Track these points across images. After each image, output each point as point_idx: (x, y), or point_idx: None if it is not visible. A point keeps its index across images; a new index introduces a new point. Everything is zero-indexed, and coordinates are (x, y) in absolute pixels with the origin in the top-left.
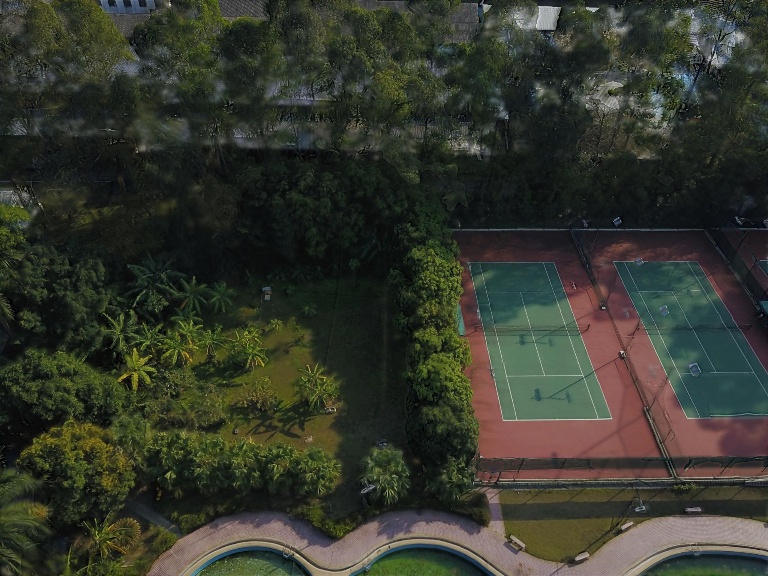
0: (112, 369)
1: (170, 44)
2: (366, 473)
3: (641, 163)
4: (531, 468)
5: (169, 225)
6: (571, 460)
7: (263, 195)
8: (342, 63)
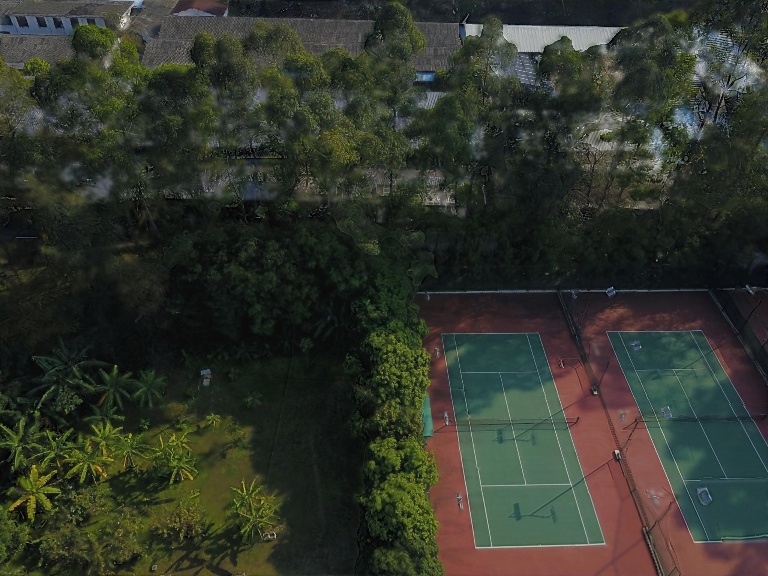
0: (9, 487)
1: (76, 98)
2: None
3: (637, 217)
4: None
5: (84, 307)
6: None
7: (197, 268)
8: (281, 121)
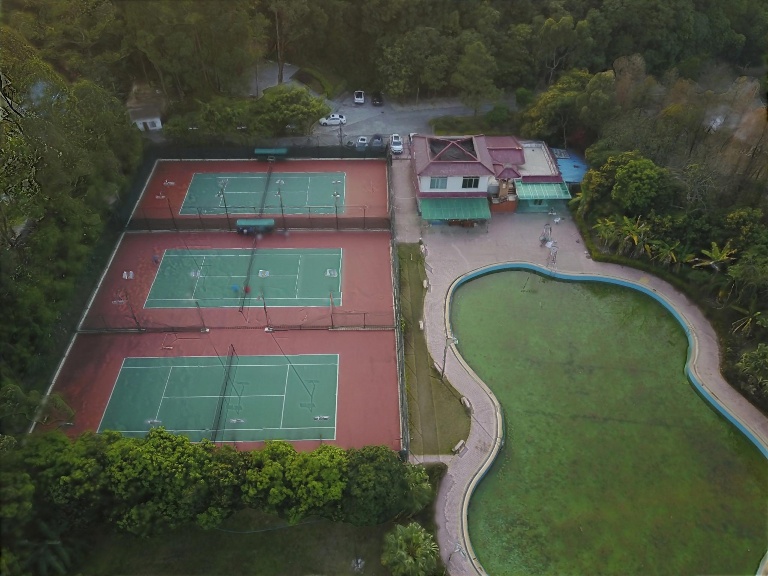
0: None
1: None
2: (415, 570)
3: None
4: None
5: None
6: None
7: None
8: None
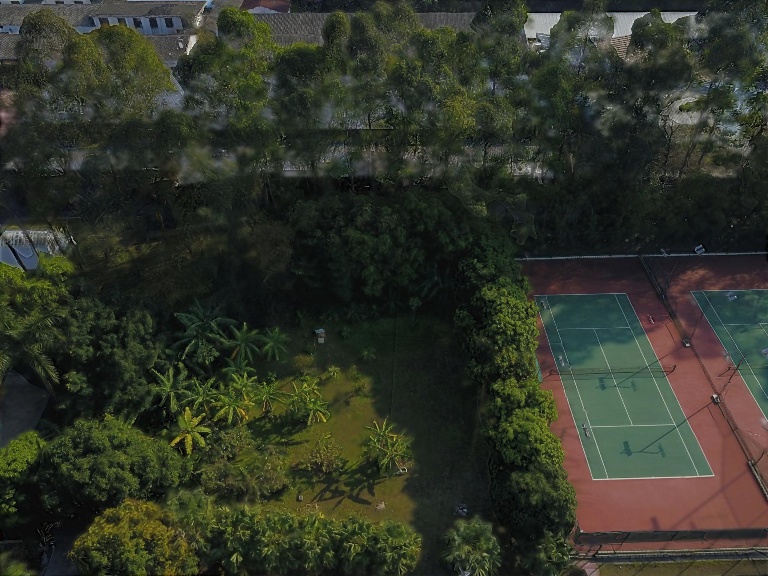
0: (162, 429)
1: (218, 75)
2: (452, 550)
3: (716, 183)
4: (636, 541)
5: (218, 268)
6: (684, 533)
7: (316, 232)
8: (406, 91)
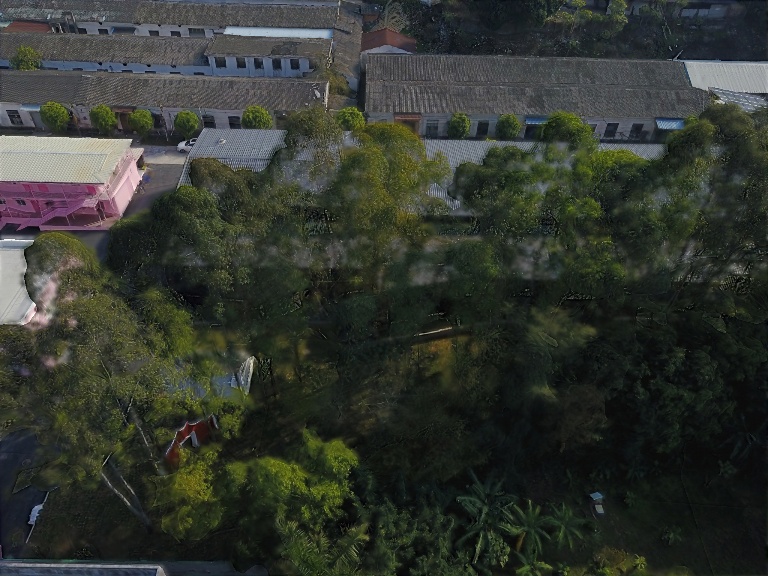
0: None
1: (542, 200)
2: None
3: None
4: None
5: (505, 436)
6: None
7: None
8: None
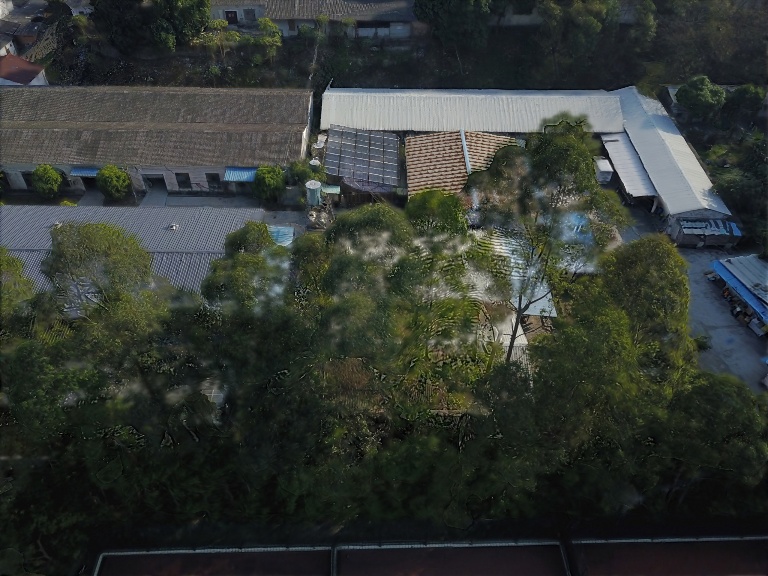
0: None
1: None
2: None
3: None
4: None
5: None
6: None
7: None
8: None
